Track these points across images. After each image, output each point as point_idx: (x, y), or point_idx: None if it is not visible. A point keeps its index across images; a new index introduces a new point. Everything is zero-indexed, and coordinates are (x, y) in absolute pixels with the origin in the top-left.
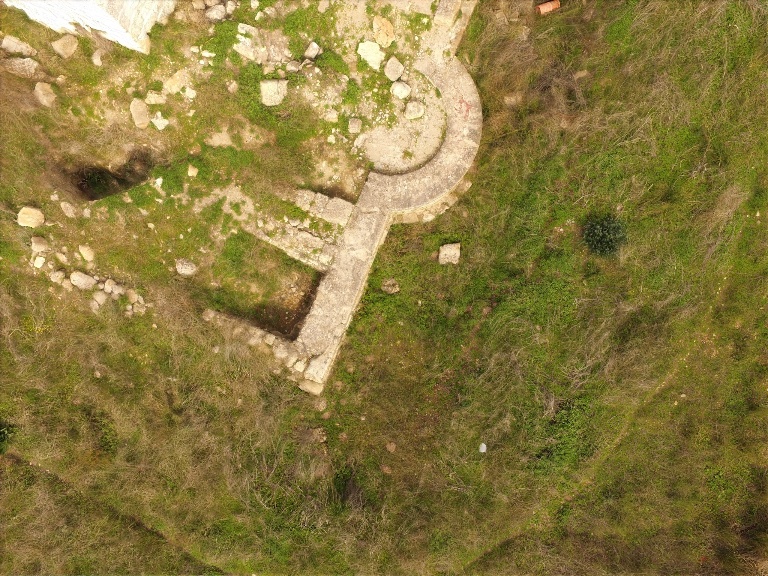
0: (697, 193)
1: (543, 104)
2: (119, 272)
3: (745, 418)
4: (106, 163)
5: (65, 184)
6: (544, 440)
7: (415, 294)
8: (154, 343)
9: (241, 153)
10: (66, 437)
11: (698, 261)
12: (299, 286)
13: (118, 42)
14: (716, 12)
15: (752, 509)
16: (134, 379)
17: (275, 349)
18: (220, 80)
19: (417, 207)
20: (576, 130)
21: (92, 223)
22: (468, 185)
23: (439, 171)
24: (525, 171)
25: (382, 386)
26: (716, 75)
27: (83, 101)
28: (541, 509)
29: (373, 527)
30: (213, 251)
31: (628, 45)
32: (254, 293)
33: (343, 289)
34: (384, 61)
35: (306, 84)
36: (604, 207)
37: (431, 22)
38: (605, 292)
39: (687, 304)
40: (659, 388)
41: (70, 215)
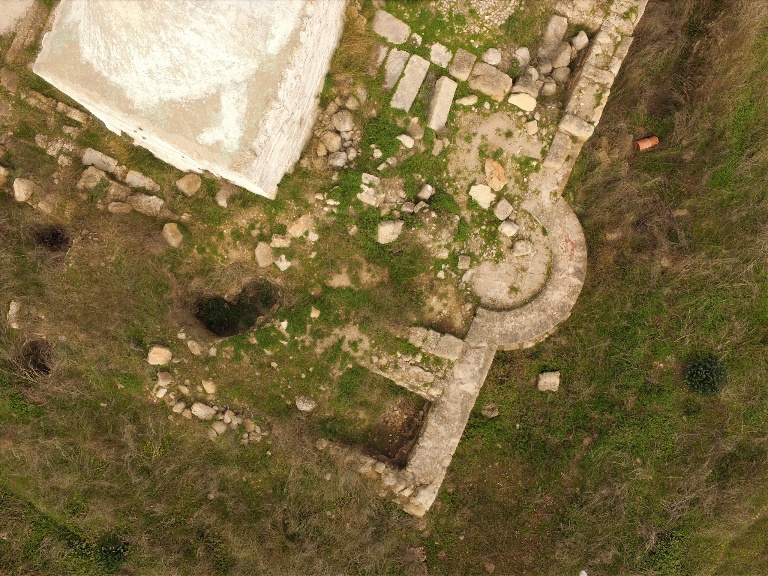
0: None
1: (645, 242)
2: (238, 404)
3: None
4: (223, 293)
5: (187, 317)
6: (644, 571)
7: (514, 418)
8: (268, 470)
9: (359, 293)
10: (181, 558)
11: None
12: (402, 409)
13: (245, 188)
14: None
15: None
16: (246, 502)
17: (384, 477)
18: (342, 226)
19: (522, 341)
20: (680, 273)
21: (217, 361)
22: (567, 314)
23: (545, 308)
24: (627, 308)
25: (483, 510)
26: None
27: (208, 241)
28: None
29: None
30: (331, 388)
31: (730, 191)
32: (362, 419)
33: (452, 422)
34: (494, 201)
35: (422, 227)
36: (705, 347)
37: (540, 165)
38: (704, 428)
39: None
40: (754, 519)
41: (196, 353)
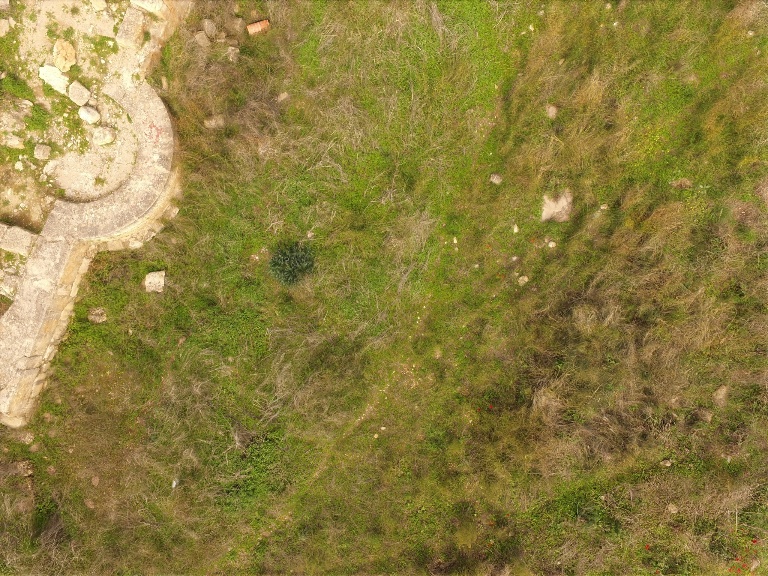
0: (387, 220)
1: (240, 128)
2: None
3: (446, 451)
4: None
5: None
6: (232, 475)
7: (124, 323)
8: None
9: None
10: None
11: (392, 290)
12: None
13: None
14: (397, 33)
15: (455, 545)
16: None
17: None
18: None
19: (108, 235)
20: (261, 156)
21: None
22: (175, 211)
23: (128, 198)
24: (217, 198)
25: None
26: (405, 98)
27: None
28: (236, 546)
29: (62, 565)
30: None
31: (316, 67)
32: None
33: (26, 321)
34: None
35: None
36: (292, 235)
37: (117, 45)
38: (297, 322)
39: (381, 334)
40: (359, 420)
41: None
